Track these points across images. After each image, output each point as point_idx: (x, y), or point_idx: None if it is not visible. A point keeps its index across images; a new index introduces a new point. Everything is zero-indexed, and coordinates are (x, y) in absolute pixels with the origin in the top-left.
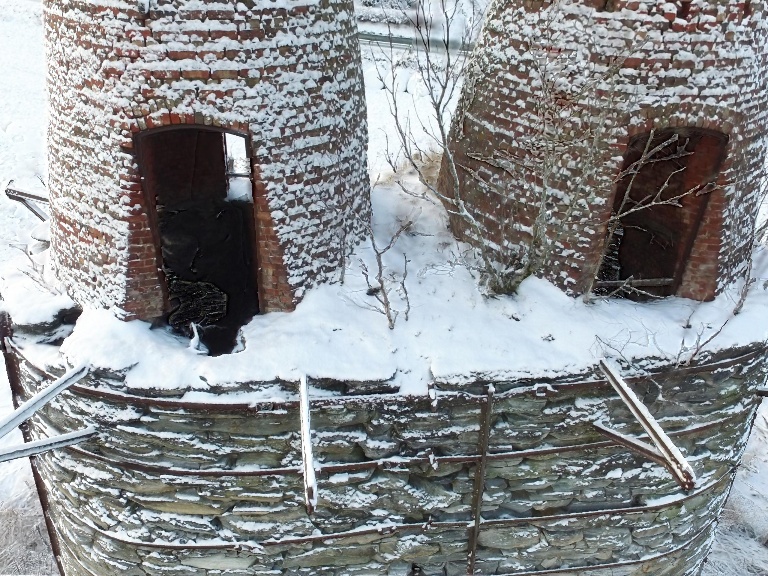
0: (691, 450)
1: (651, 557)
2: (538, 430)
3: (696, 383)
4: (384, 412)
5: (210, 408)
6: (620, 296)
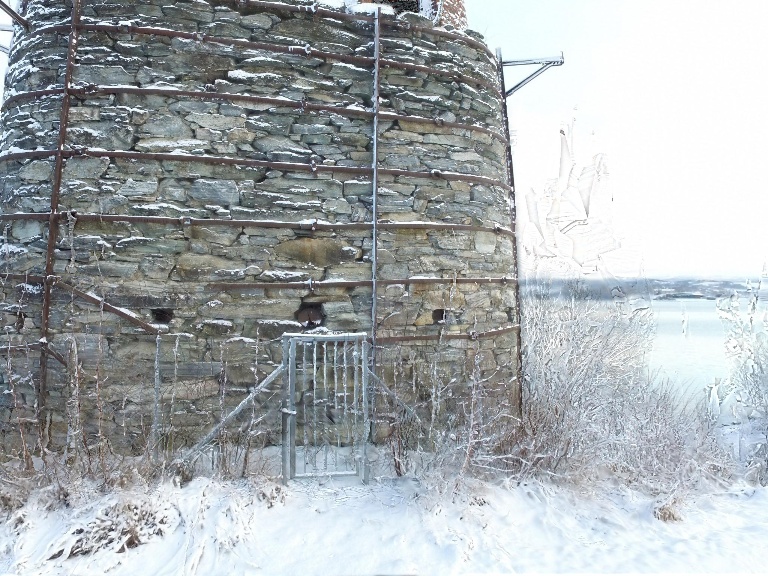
0: None
1: None
2: None
3: None
4: None
5: None
6: (25, 106)
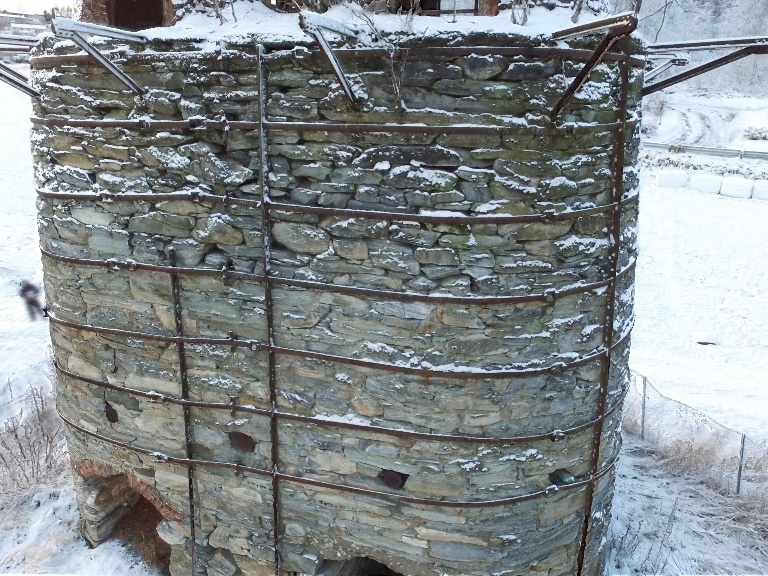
0: (470, 163)
1: (441, 296)
2: (308, 104)
3: (451, 68)
4: (191, 71)
5: (88, 60)
6: None
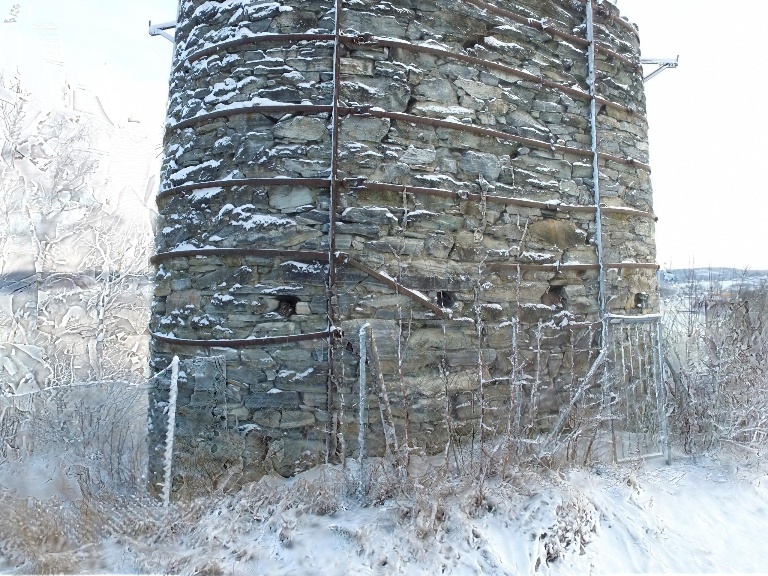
0: None
1: None
2: None
3: None
4: None
5: None
6: (273, 50)
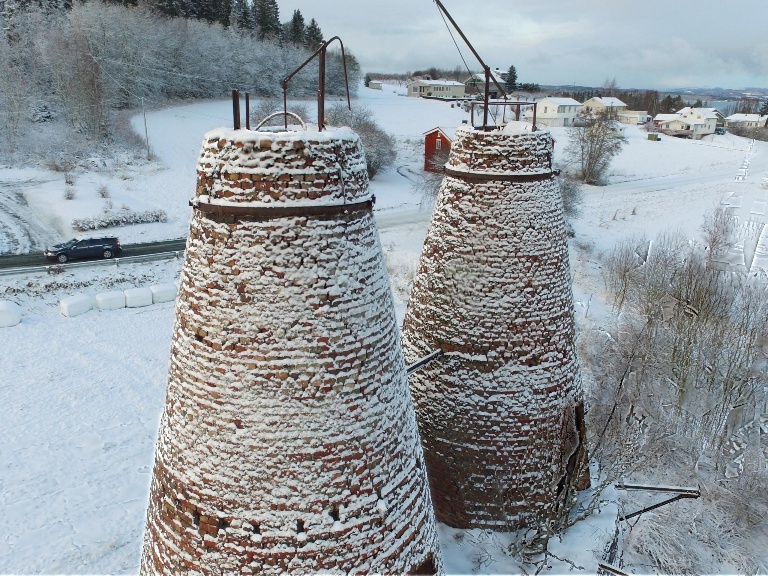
0: None
1: None
2: None
3: None
4: None
5: None
6: None
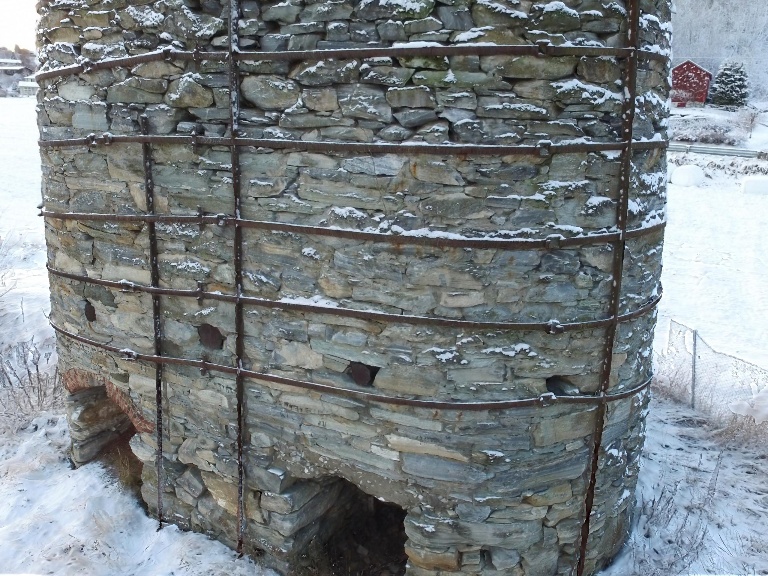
0: None
1: (414, 144)
2: None
3: None
4: None
5: None
6: None
